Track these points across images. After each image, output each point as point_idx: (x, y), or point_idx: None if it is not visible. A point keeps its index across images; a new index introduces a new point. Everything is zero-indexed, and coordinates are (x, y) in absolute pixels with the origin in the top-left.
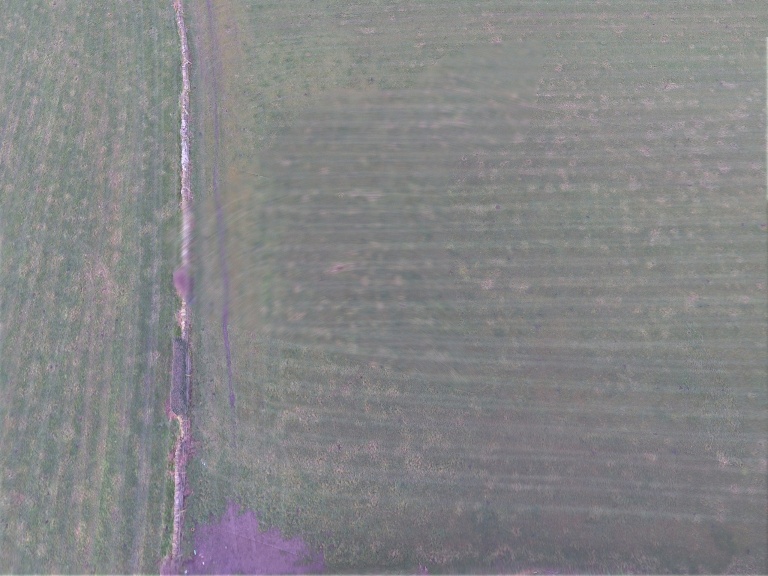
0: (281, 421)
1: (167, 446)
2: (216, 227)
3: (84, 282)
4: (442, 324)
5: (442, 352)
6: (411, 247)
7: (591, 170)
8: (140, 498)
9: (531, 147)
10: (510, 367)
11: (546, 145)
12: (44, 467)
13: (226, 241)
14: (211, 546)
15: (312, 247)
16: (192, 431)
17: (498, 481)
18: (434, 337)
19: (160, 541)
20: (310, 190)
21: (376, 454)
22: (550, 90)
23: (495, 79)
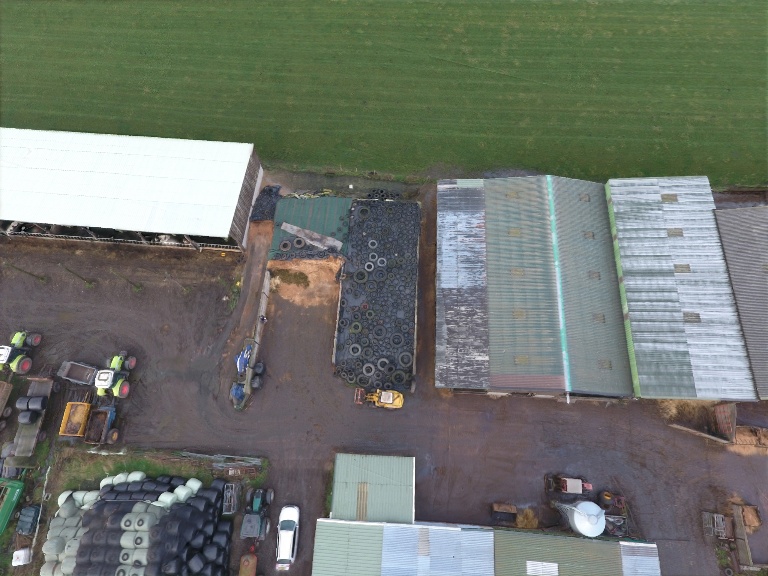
0: None
1: None
2: None
3: None
4: (1, 16)
5: None
6: None
7: None
8: None
9: None
10: (35, 39)
11: None
12: None
13: None
14: None
15: None
16: None
17: None
18: None
19: None
20: None
21: None
22: None
23: None
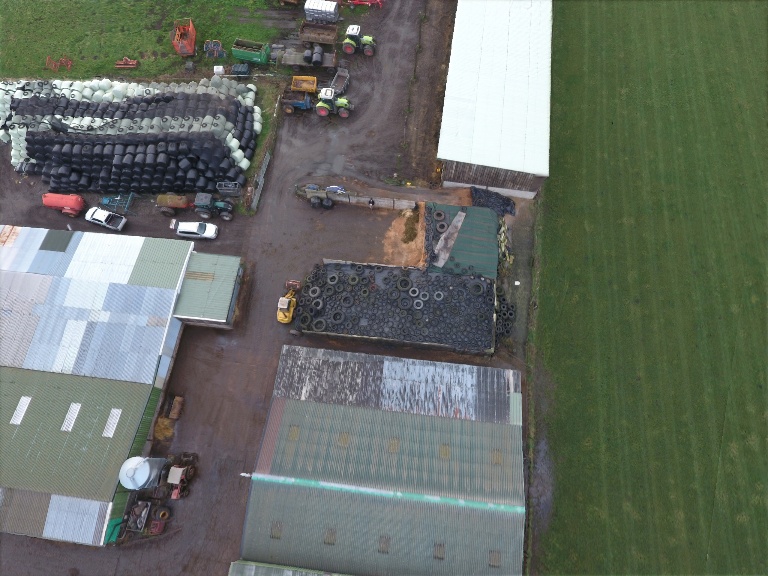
0: None
1: None
2: None
3: None
4: None
5: None
6: None
7: None
8: None
9: None
10: None
11: None
12: None
13: None
14: None
15: None
16: None
17: None
18: None
19: None
20: None
21: None
22: None
23: None
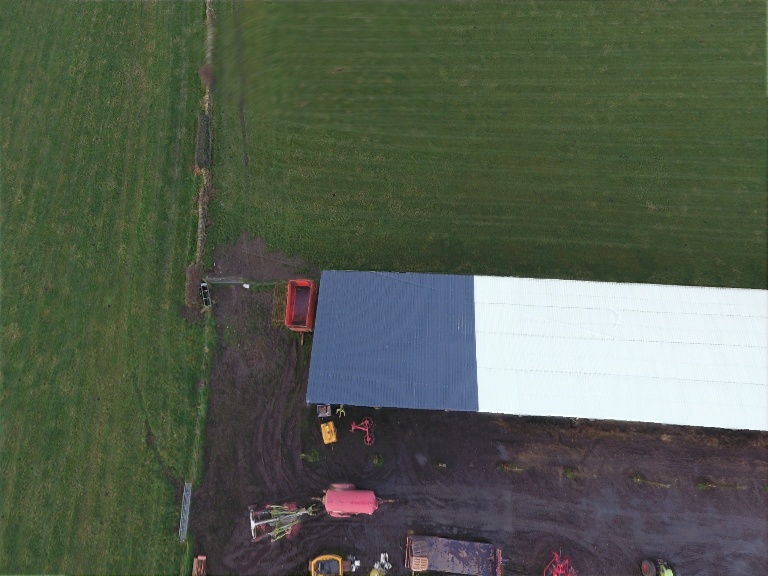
0: (286, 176)
1: (192, 193)
2: (235, 39)
3: (124, 79)
4: (423, 111)
5: (422, 130)
6: (400, 56)
7: (557, 1)
8: (170, 229)
9: None
10: (479, 141)
11: None
12: (91, 207)
13: (243, 49)
14: (227, 261)
15: (316, 55)
16: (213, 182)
17: (464, 219)
18: (416, 120)
19: (186, 257)
20: (315, 13)
21: (364, 200)
22: None
23: None
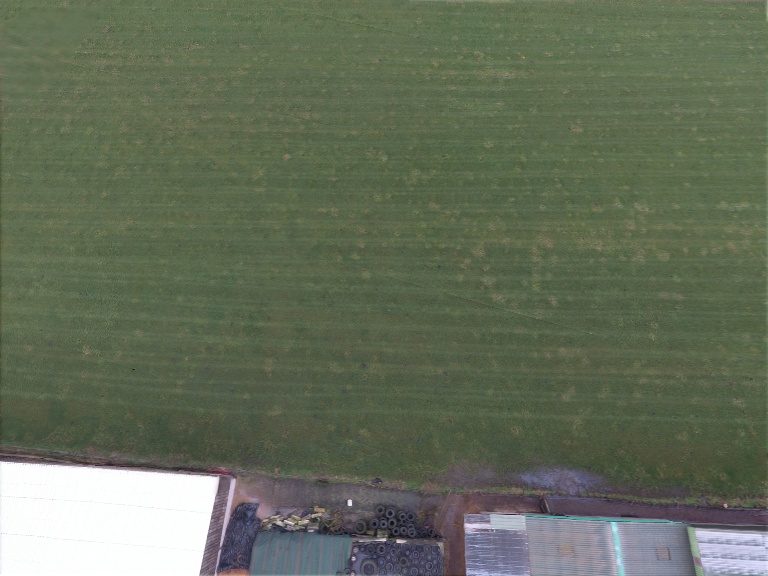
0: None
1: None
2: None
3: None
4: None
5: None
6: None
7: (93, 116)
8: None
9: (50, 96)
10: None
11: (64, 94)
12: None
13: None
14: None
15: None
16: None
17: None
18: None
19: None
20: None
21: None
22: (89, 48)
23: (46, 38)
